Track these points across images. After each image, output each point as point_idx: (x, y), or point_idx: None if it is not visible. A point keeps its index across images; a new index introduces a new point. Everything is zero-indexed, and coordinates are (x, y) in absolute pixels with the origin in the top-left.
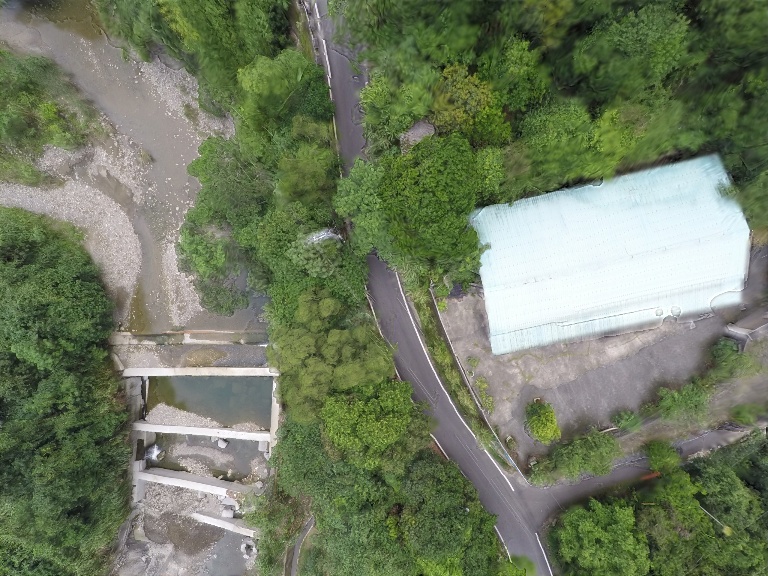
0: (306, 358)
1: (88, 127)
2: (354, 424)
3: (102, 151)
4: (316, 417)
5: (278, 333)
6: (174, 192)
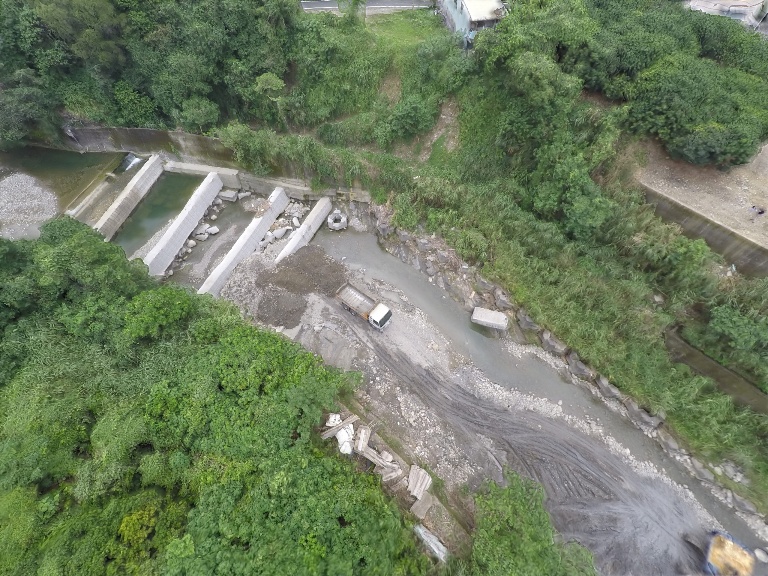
0: None
1: None
2: None
3: None
4: None
5: None
6: None
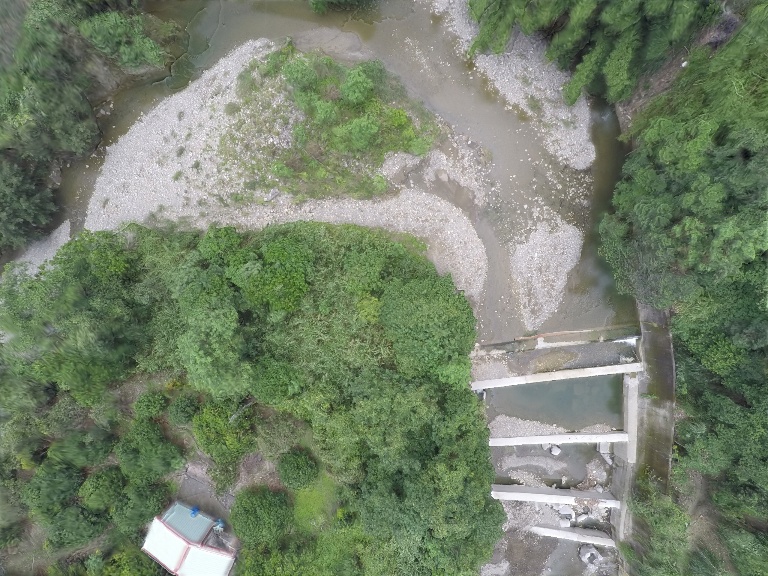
0: None
1: (426, 130)
2: None
3: (441, 154)
4: None
5: None
6: (520, 190)
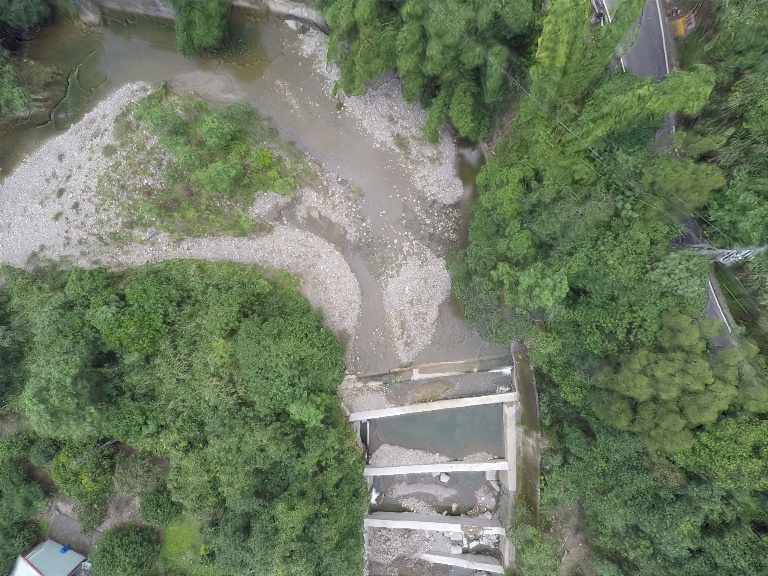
0: (713, 383)
1: (295, 169)
2: (763, 445)
3: (311, 192)
4: (697, 442)
5: (647, 359)
6: (390, 225)
